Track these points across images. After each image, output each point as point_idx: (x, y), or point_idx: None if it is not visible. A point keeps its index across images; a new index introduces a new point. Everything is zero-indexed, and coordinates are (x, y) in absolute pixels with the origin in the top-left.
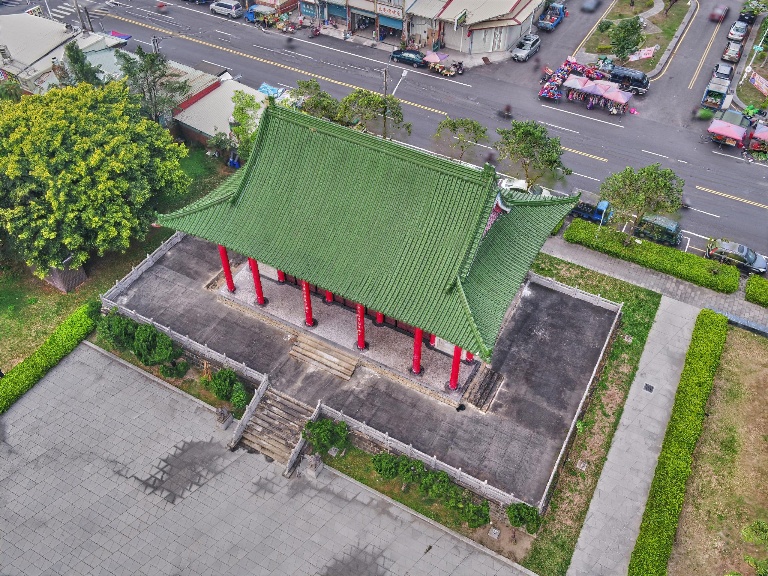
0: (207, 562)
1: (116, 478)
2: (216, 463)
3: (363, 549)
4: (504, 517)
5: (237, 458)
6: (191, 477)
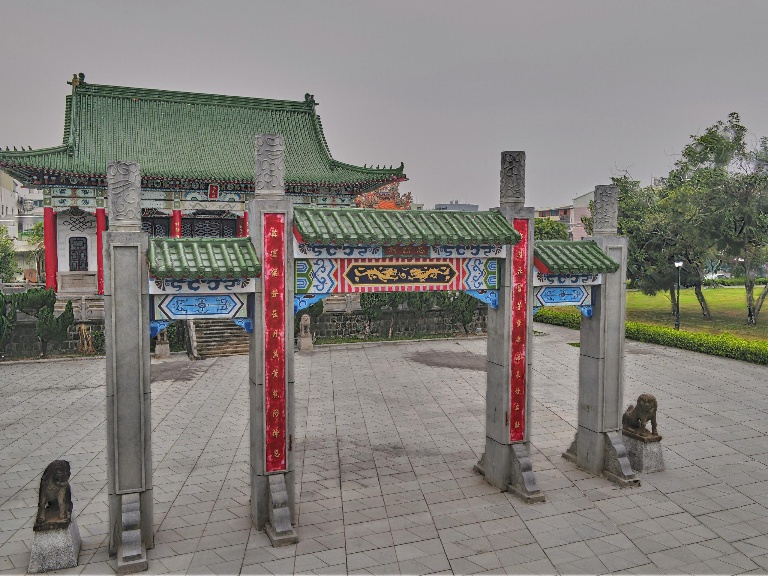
0: (302, 381)
1: (77, 390)
2: (197, 364)
3: (417, 352)
4: (474, 323)
5: (216, 360)
6: (183, 372)
